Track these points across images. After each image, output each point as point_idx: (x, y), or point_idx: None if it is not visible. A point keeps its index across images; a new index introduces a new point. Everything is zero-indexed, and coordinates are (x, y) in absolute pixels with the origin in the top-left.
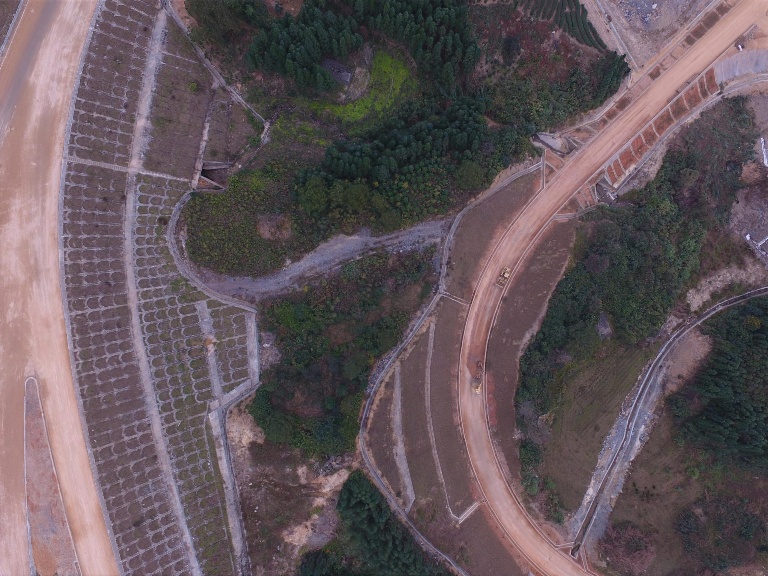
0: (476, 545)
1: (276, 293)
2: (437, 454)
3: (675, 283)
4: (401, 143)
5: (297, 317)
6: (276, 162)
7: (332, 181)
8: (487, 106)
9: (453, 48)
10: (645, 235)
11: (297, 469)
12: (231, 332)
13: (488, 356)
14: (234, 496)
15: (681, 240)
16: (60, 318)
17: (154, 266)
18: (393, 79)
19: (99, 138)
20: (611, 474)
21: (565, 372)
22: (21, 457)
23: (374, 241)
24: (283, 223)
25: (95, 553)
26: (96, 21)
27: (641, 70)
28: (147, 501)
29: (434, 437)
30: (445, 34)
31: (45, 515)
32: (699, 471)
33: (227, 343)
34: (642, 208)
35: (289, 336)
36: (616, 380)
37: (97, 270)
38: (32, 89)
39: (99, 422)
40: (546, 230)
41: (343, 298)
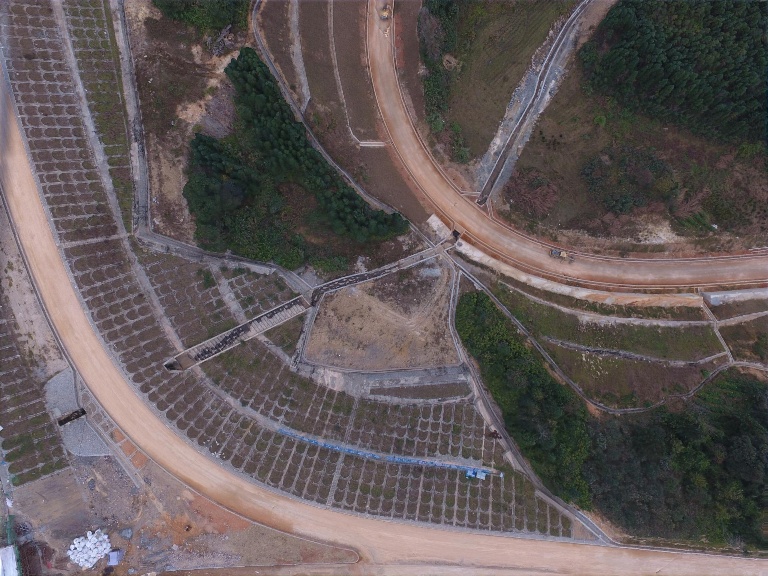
0: (377, 171)
1: None
2: (339, 74)
3: None
4: None
5: None
6: None
7: None
8: None
9: None
10: None
11: (192, 48)
12: None
13: None
14: (130, 69)
15: None
16: None
17: None
18: None
19: None
20: (520, 130)
21: (474, 19)
22: None
23: None
24: None
25: None
26: None
27: None
28: (40, 43)
29: (336, 58)
30: None
31: None
32: (607, 120)
33: None
34: None
35: None
36: (526, 32)
37: None
38: None
39: None
40: None
41: None
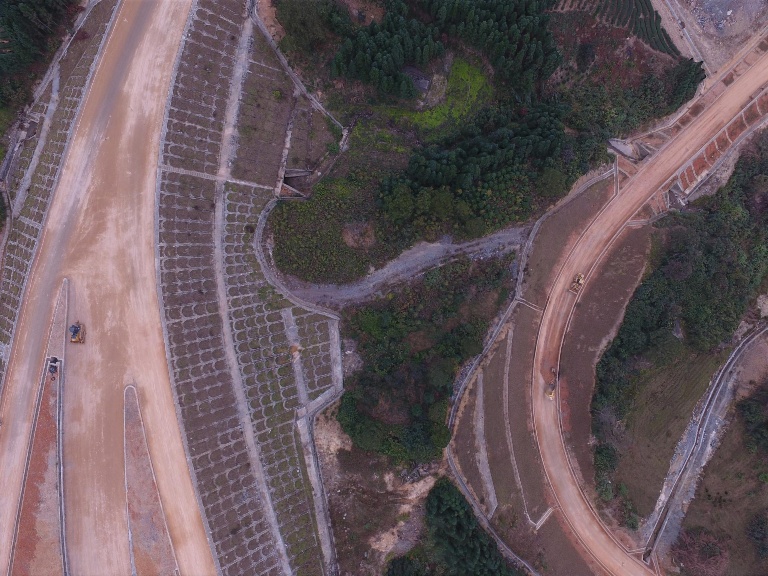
0: (553, 551)
1: (360, 300)
2: (515, 460)
3: (748, 289)
4: (485, 151)
5: (379, 324)
6: (360, 170)
7: (417, 189)
8: (566, 113)
9: (534, 55)
10: (722, 241)
11: (384, 476)
12: (315, 339)
13: (562, 362)
14: (322, 503)
15: (752, 246)
16: (157, 327)
17: (242, 274)
18: (470, 86)
19: (190, 147)
20: (682, 480)
21: (637, 378)
22: (121, 465)
23: (455, 248)
24: (366, 230)
25: (195, 561)
26: (188, 30)
27: (714, 76)
28: (242, 509)
29: (512, 443)
30: (528, 42)
31: (146, 523)
32: None
33: (312, 350)
34: (714, 214)
35: (371, 343)
36: (687, 386)
37: (190, 278)
38: (126, 98)
39: (196, 430)
40: (620, 236)
41: (424, 305)
